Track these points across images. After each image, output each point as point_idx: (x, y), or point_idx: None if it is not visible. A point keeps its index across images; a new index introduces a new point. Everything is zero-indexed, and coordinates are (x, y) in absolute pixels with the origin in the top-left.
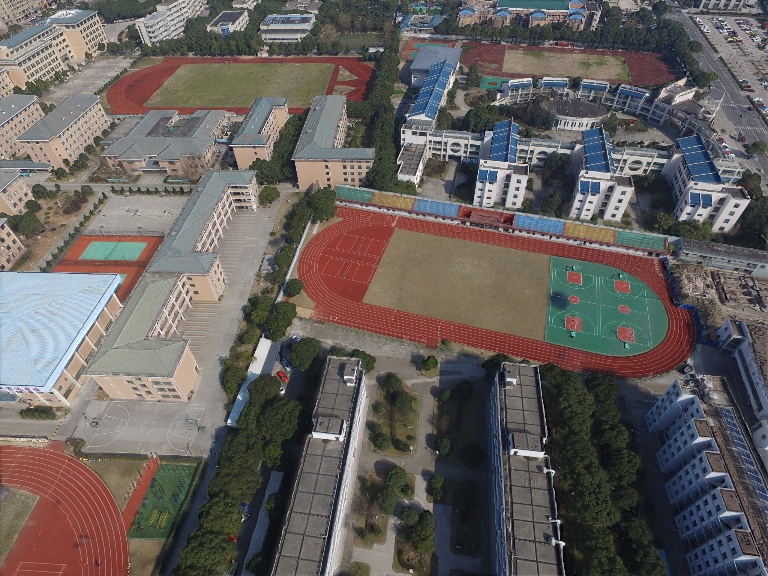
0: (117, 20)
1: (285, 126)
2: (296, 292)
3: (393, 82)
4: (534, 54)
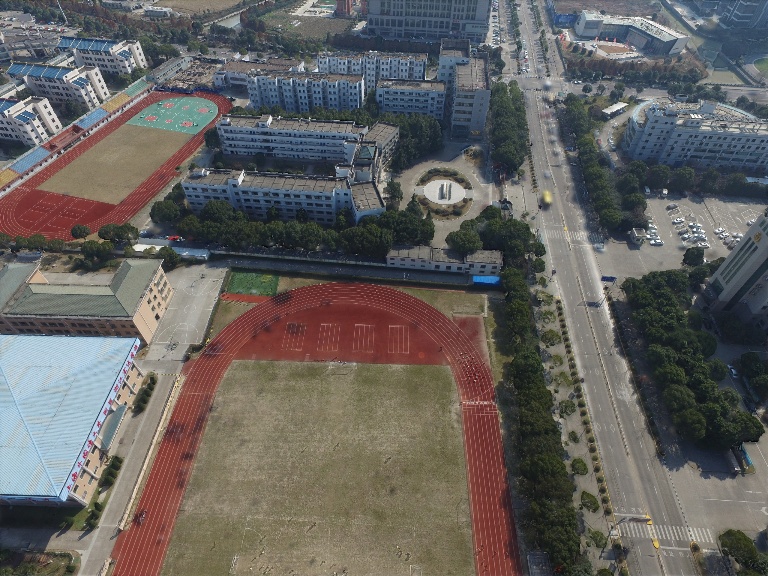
0: None
1: None
2: (88, 230)
3: None
4: None
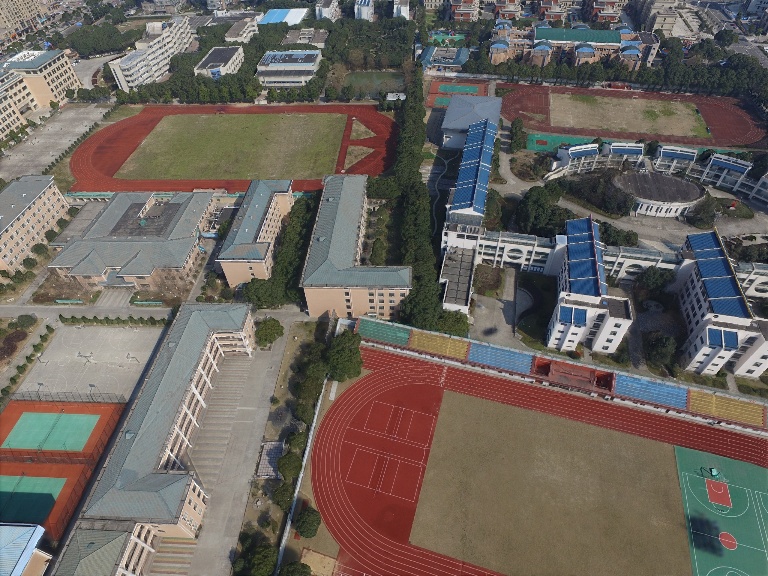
0: (93, 55)
1: (289, 216)
2: (311, 535)
3: (421, 146)
4: (585, 99)
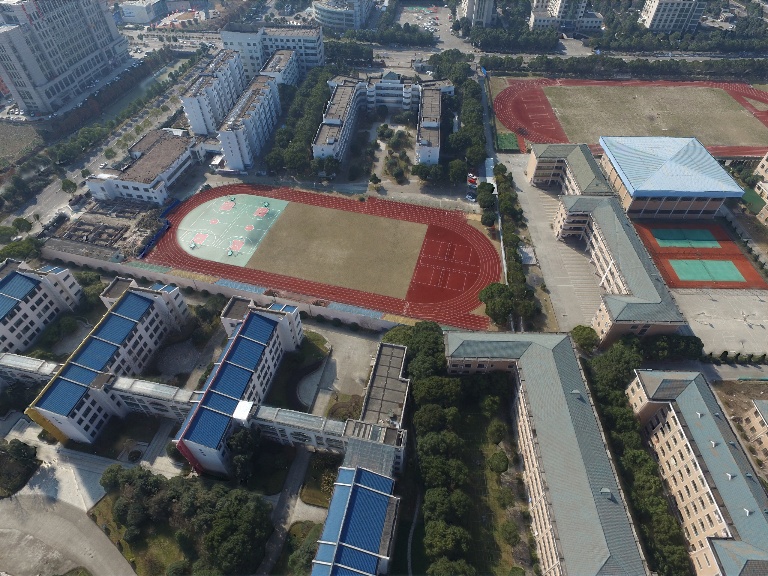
0: None
1: None
2: None
3: None
4: None
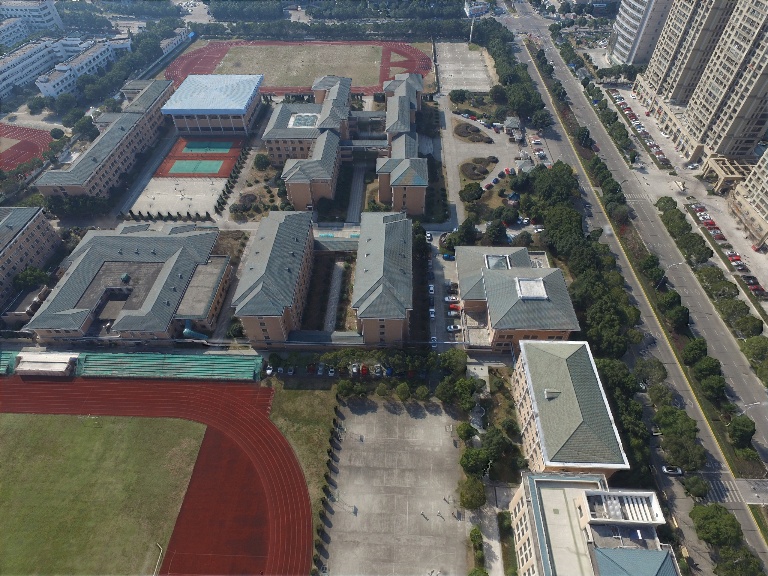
0: None
1: None
2: None
3: None
4: None
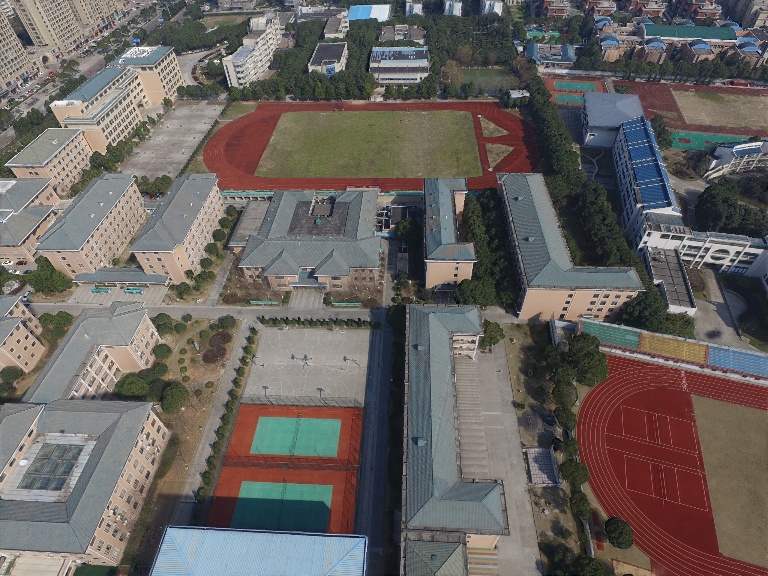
0: (185, 51)
1: (465, 215)
2: (628, 546)
3: (570, 144)
4: (711, 97)
